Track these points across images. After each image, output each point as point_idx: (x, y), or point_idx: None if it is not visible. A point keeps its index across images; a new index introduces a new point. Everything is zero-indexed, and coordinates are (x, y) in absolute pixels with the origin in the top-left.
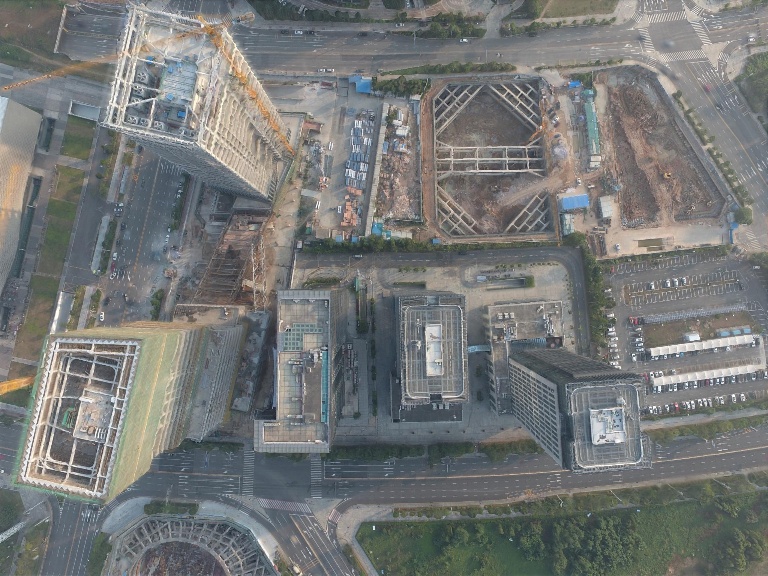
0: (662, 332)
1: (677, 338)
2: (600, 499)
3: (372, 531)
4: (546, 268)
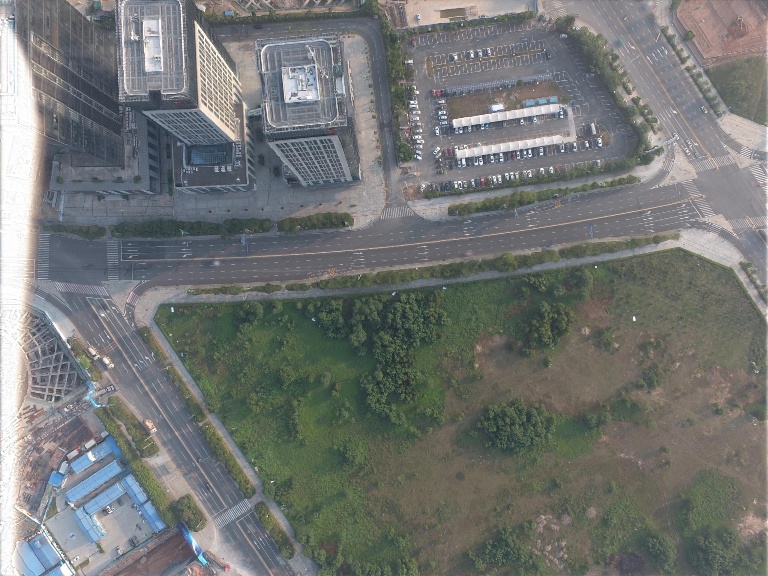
0: (466, 105)
1: (482, 110)
2: (402, 274)
3: (171, 313)
4: (345, 41)
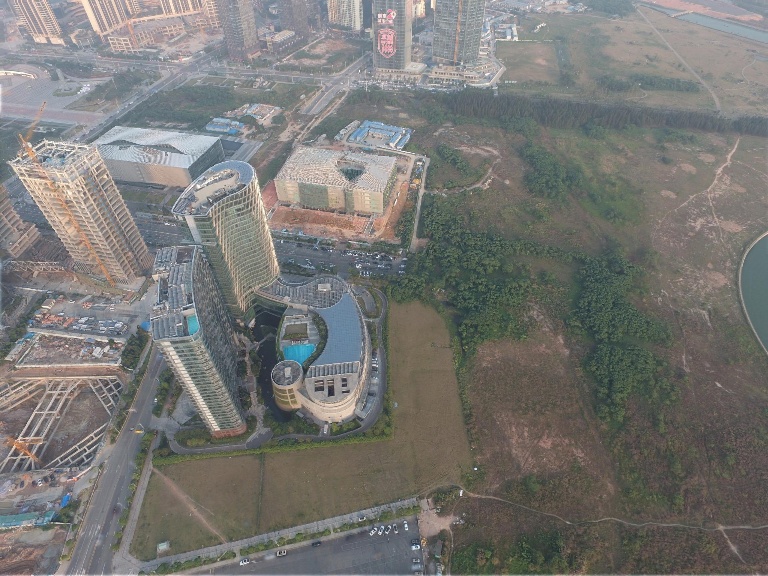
0: None
1: None
2: None
3: None
4: None
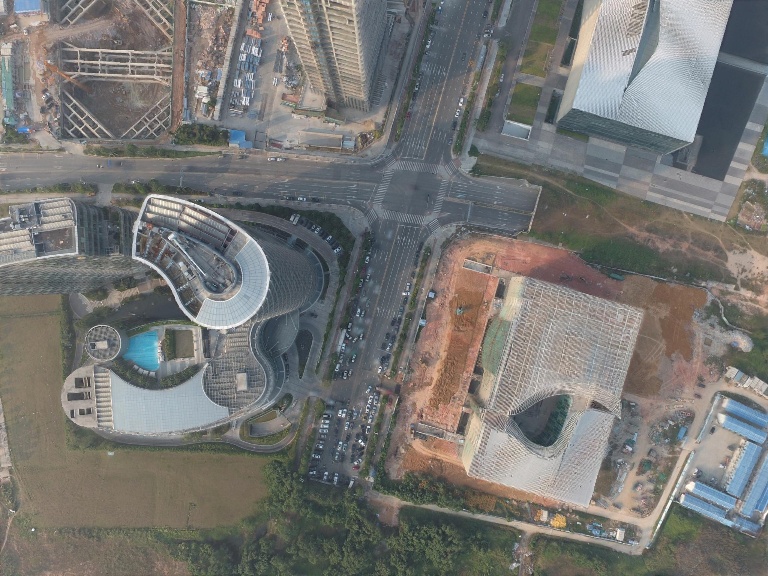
0: None
1: None
2: None
3: None
4: None
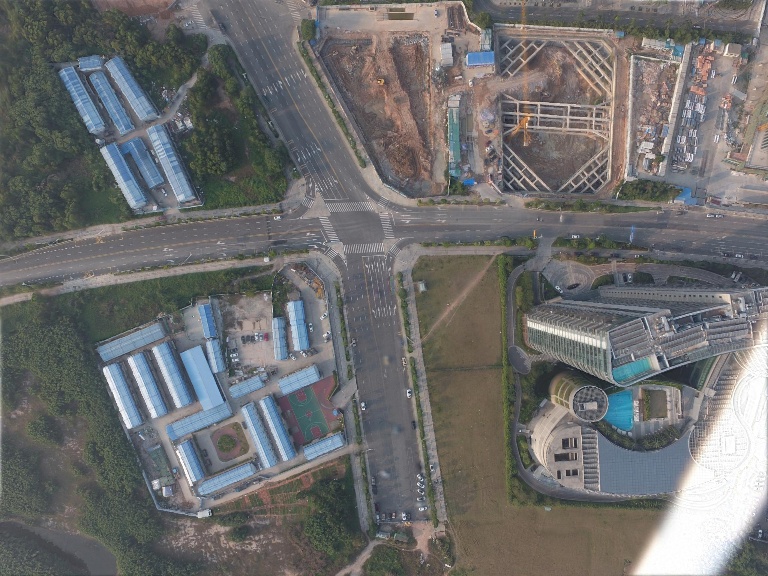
0: None
1: None
2: None
3: None
4: None
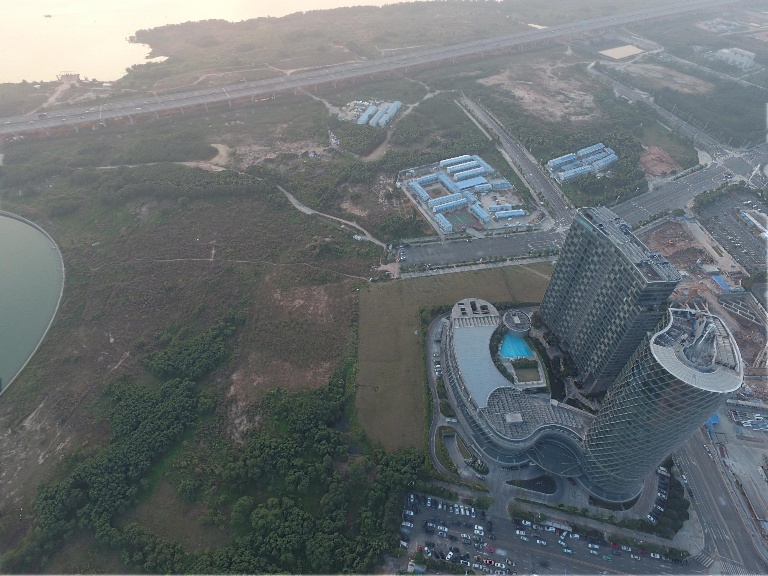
0: None
1: None
2: None
3: None
4: None
